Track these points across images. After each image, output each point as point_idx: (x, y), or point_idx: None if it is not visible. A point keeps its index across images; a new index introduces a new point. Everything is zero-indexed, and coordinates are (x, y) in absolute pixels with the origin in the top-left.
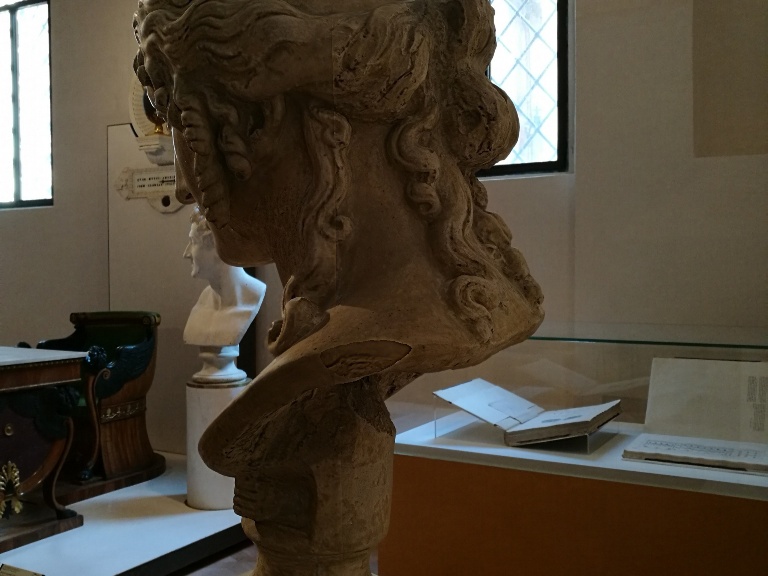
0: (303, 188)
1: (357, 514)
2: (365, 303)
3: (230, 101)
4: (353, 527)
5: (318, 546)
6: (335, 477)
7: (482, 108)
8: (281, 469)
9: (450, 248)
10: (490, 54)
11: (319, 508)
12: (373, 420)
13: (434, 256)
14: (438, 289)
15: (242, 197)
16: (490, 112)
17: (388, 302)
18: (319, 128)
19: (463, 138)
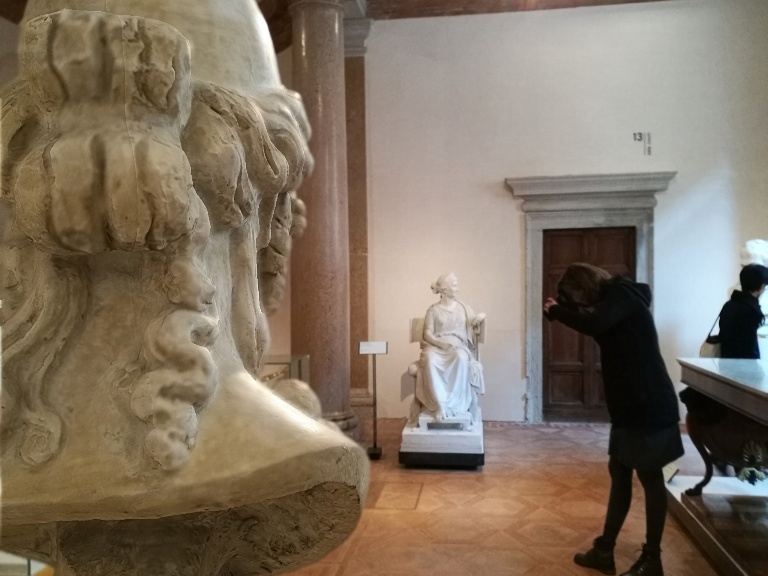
0: None
1: None
2: None
3: None
4: None
5: None
6: None
7: None
8: None
9: None
10: (123, 89)
11: None
12: (81, 563)
13: None
14: None
15: None
16: None
17: None
18: None
19: None
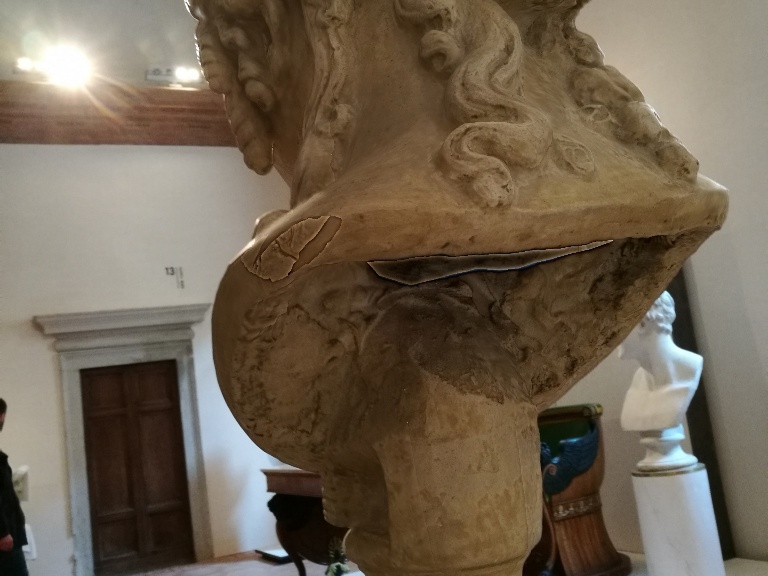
0: None
1: (447, 512)
2: None
3: (238, 24)
4: (444, 531)
5: (399, 557)
6: (405, 458)
7: None
8: (353, 455)
9: (460, 98)
10: None
11: (390, 502)
12: (454, 378)
13: (447, 117)
14: (433, 151)
15: (283, 134)
16: None
17: (347, 178)
18: (313, 13)
19: None
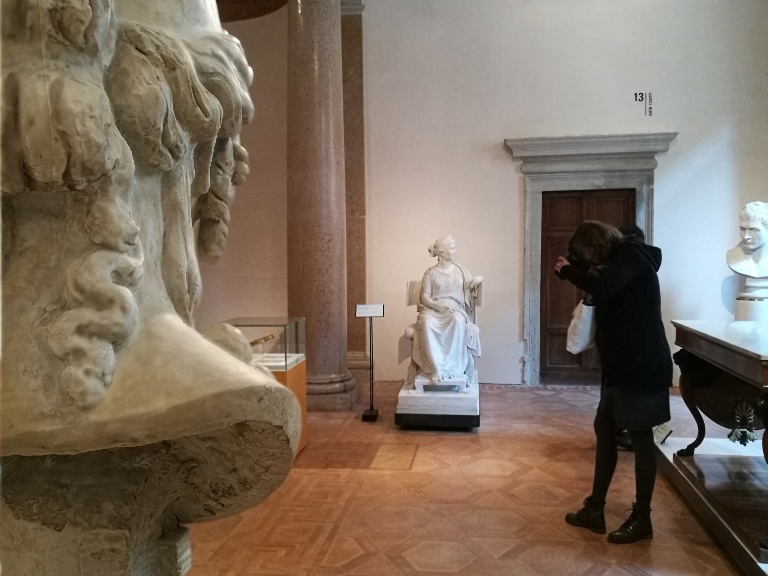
0: None
1: None
2: None
3: None
4: None
5: None
6: None
7: None
8: None
9: None
10: (38, 27)
11: None
12: (19, 502)
13: None
14: None
15: None
16: None
17: None
18: None
19: None
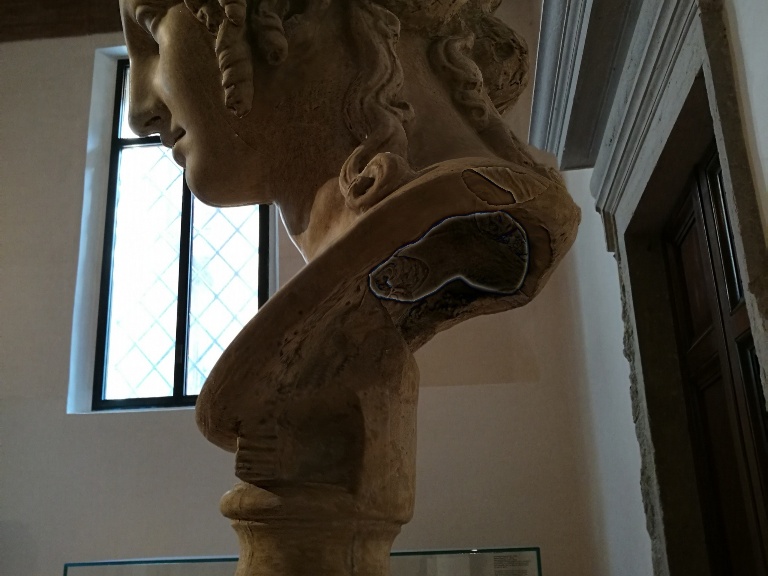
0: (346, 81)
1: (403, 464)
2: (471, 156)
3: None
4: (399, 481)
5: (364, 501)
6: (383, 410)
7: (514, 41)
8: (311, 404)
9: (515, 146)
10: None
11: (367, 448)
12: None
13: (498, 154)
14: None
15: (262, 91)
16: (522, 45)
17: None
18: (370, 19)
19: (498, 66)
